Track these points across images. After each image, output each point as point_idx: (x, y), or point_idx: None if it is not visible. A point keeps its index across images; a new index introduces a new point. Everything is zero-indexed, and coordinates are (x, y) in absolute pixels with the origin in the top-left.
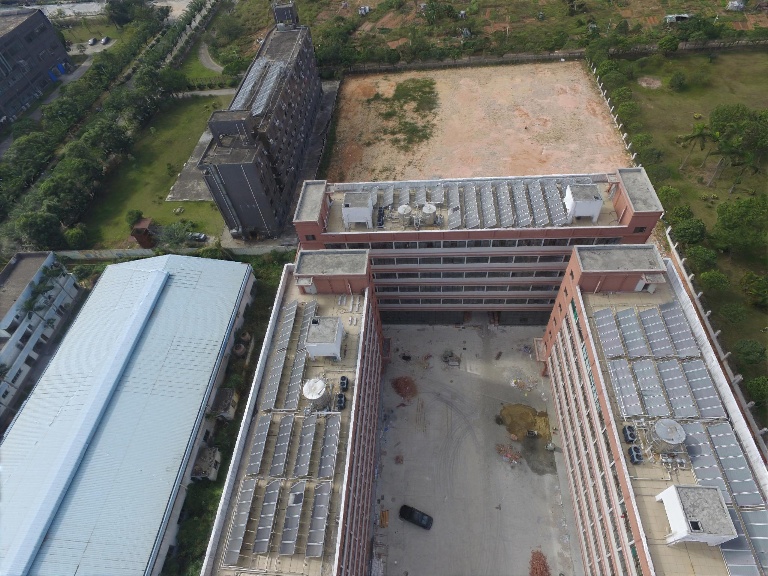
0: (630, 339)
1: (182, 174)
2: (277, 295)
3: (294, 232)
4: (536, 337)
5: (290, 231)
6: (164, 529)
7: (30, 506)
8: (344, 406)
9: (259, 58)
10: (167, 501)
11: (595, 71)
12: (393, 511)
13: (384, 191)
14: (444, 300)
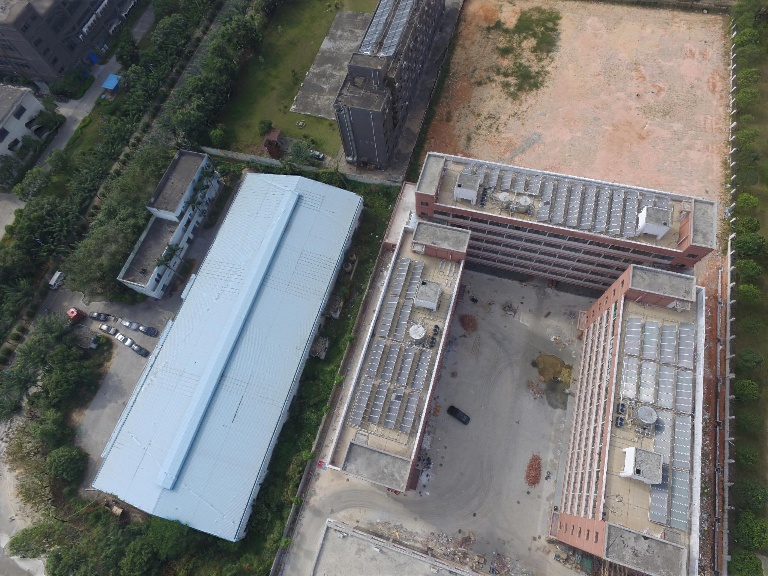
0: (647, 344)
1: (304, 84)
2: (395, 251)
3: (399, 167)
4: (582, 306)
5: (396, 166)
6: (294, 385)
7: (210, 353)
8: (434, 345)
9: None
10: (296, 369)
11: (734, 35)
12: (444, 407)
13: (491, 171)
14: (516, 264)
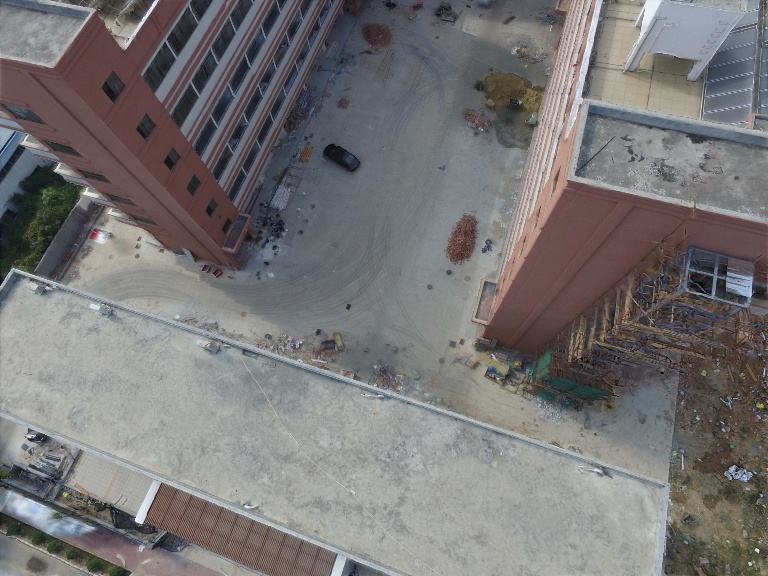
0: None
1: None
2: None
3: None
4: None
5: None
6: None
7: None
8: None
9: None
10: None
11: None
12: (318, 149)
13: None
14: None
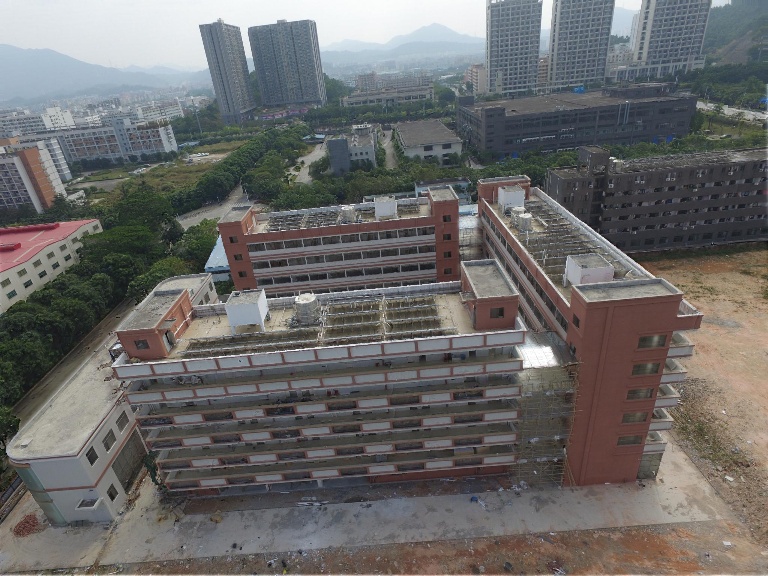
0: None
1: None
2: None
3: None
4: None
5: None
6: None
7: None
8: None
9: (734, 152)
10: None
11: None
12: None
13: None
14: None
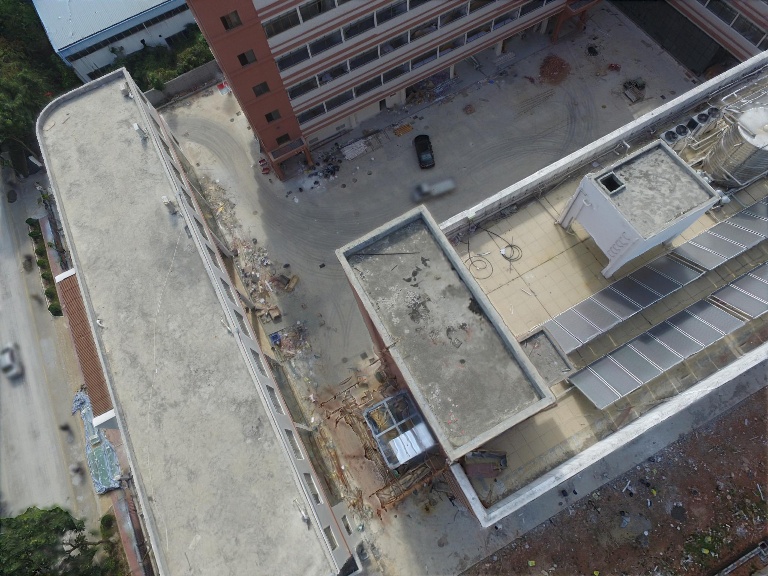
0: None
1: None
2: None
3: None
4: None
5: None
6: None
7: None
8: None
9: None
10: None
11: None
12: (416, 133)
13: None
14: None
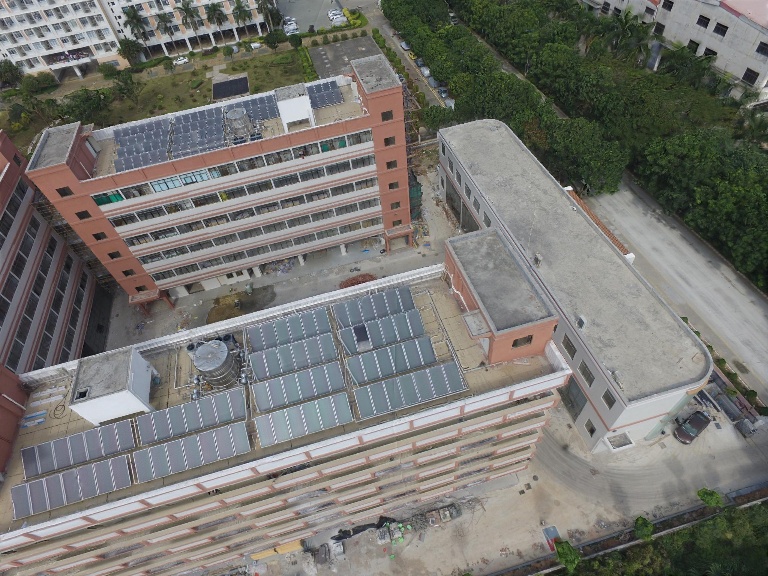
0: None
1: None
2: None
3: None
4: (125, 320)
5: None
6: None
7: None
8: None
9: None
10: None
11: None
12: None
13: None
14: None
